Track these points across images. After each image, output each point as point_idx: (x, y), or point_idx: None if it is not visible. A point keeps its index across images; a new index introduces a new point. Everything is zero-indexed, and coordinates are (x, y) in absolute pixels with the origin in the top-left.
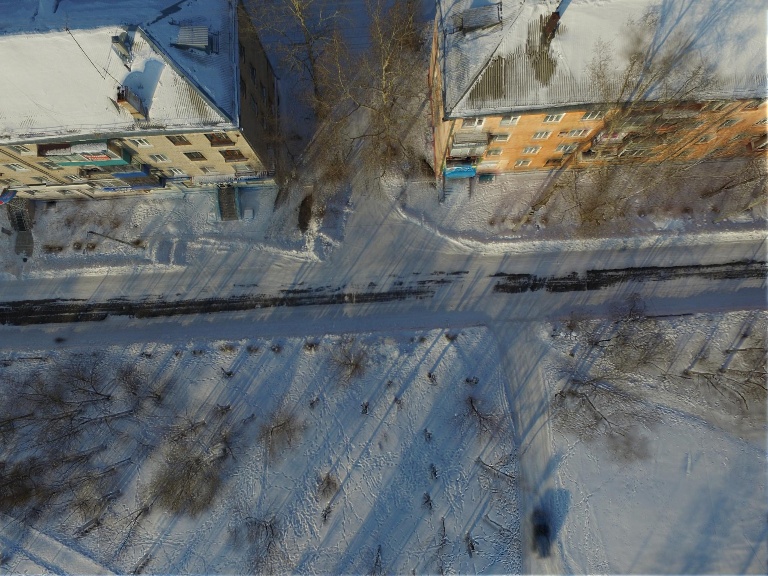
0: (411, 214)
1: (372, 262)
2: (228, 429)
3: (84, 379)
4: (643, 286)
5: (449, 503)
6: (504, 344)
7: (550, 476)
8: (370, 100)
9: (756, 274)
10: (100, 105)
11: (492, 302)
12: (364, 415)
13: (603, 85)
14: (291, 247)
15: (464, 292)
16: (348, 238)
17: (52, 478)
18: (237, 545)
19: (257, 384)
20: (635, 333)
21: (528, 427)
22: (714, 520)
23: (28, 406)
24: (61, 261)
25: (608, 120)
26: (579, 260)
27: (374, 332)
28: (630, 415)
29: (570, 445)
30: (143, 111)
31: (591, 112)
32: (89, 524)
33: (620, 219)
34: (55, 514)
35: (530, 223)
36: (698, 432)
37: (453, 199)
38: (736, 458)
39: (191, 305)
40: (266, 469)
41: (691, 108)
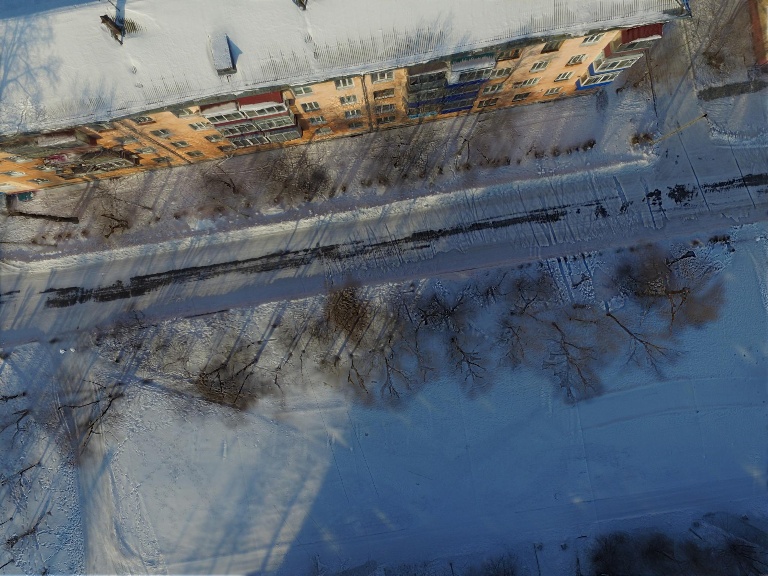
0: None
1: None
2: None
3: None
4: (184, 287)
5: (15, 505)
6: (57, 357)
7: (105, 472)
8: None
9: (290, 264)
10: None
11: (43, 318)
12: None
13: None
14: None
15: (17, 311)
16: None
17: None
18: None
19: None
20: (173, 334)
21: (84, 431)
22: (247, 495)
23: None
24: None
25: None
26: (122, 268)
27: None
28: (172, 411)
29: (119, 443)
30: None
31: None
32: None
33: (158, 223)
34: None
35: (71, 237)
36: (232, 420)
37: None
38: (266, 439)
39: None
40: None
41: (59, 134)
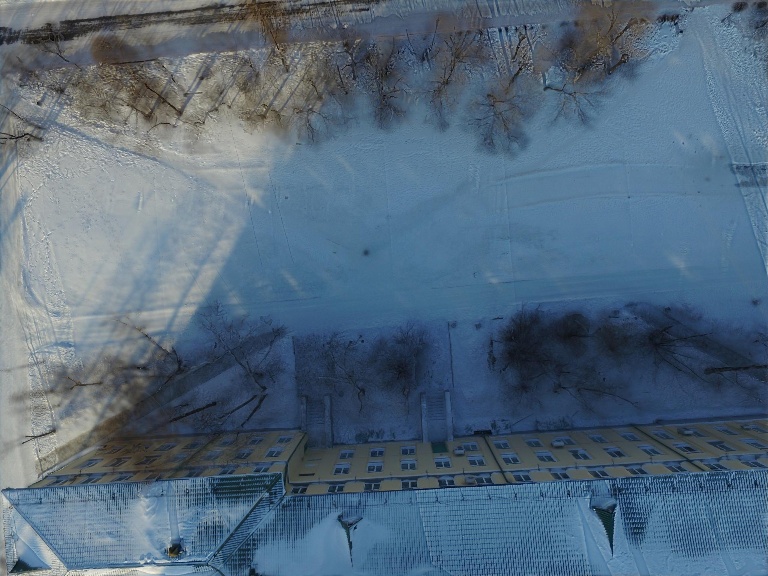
0: None
1: None
2: None
3: None
4: (113, 35)
5: None
6: None
7: (17, 218)
8: None
9: (224, 18)
10: None
11: None
12: None
13: None
14: None
15: None
16: None
17: None
18: None
19: None
20: (98, 80)
21: None
22: (159, 251)
23: None
24: None
25: None
26: (53, 11)
27: None
28: (90, 159)
29: (34, 189)
30: None
31: None
32: None
33: None
34: None
35: None
36: (151, 172)
37: None
38: (184, 195)
39: None
40: None
41: None
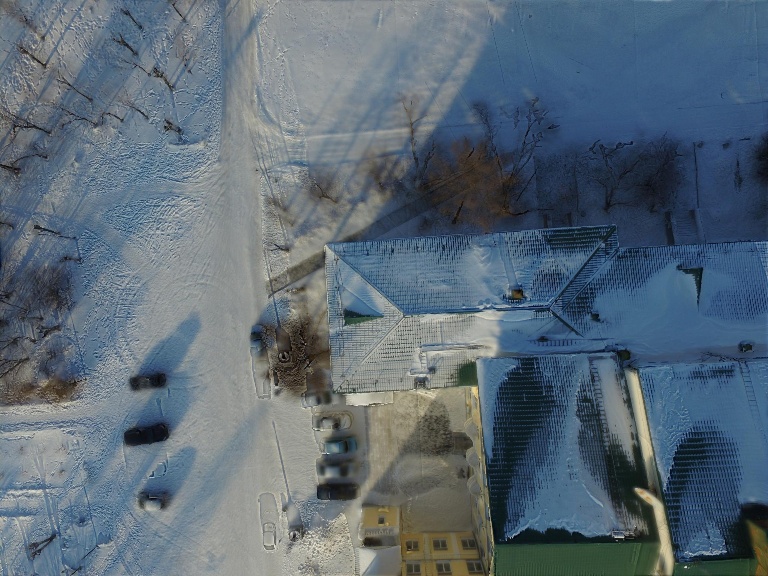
0: None
1: None
2: None
3: None
4: None
5: (155, 60)
6: None
7: (251, 36)
8: None
9: None
10: None
11: None
12: None
13: None
14: None
15: None
16: None
17: None
18: None
19: None
20: None
21: None
22: (399, 69)
23: None
24: None
25: None
26: None
27: None
28: None
29: (270, 5)
30: None
31: None
32: None
33: None
34: None
35: None
36: None
37: None
38: (425, 12)
39: None
40: None
41: None
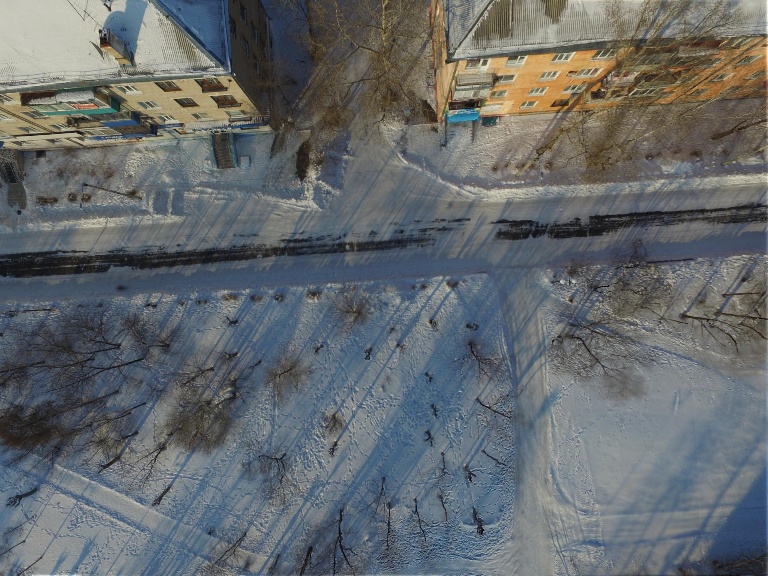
0: (412, 159)
1: (373, 210)
2: (237, 375)
3: (94, 329)
4: (645, 231)
5: (449, 440)
6: (504, 291)
7: (544, 414)
8: (368, 39)
9: (760, 218)
10: (82, 49)
11: (493, 249)
12: (367, 360)
13: (617, 20)
14: (290, 195)
15: (465, 239)
16: (348, 185)
17: (73, 422)
18: (252, 479)
19: (263, 332)
20: (634, 279)
21: (525, 370)
22: (696, 452)
23: (42, 356)
24: (58, 212)
25: (620, 58)
26: (582, 205)
27: (376, 281)
28: (624, 357)
29: (565, 386)
30: (128, 56)
31: (603, 50)
32: (112, 462)
33: (626, 162)
34: (80, 454)
35: (534, 167)
36: (688, 373)
37: (455, 143)
38: (722, 396)
39: (193, 256)
40: (275, 411)
41: (709, 44)
